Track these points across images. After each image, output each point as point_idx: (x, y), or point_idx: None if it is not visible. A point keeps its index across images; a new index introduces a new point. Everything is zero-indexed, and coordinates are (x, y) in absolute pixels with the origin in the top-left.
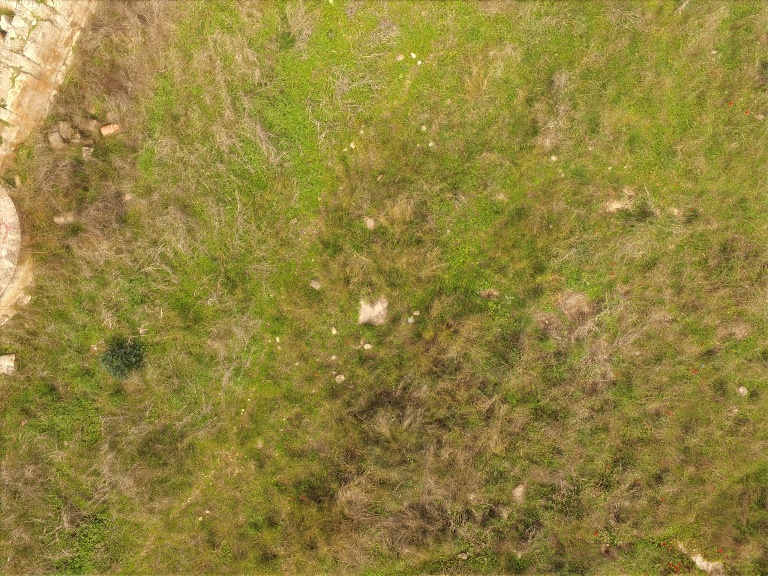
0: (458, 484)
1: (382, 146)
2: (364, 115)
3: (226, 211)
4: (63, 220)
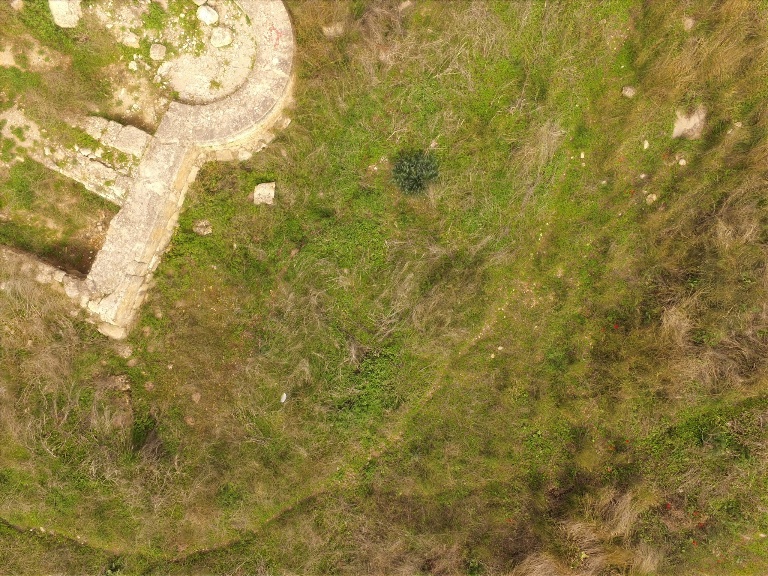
0: None
1: None
2: None
3: (531, 9)
4: (333, 30)
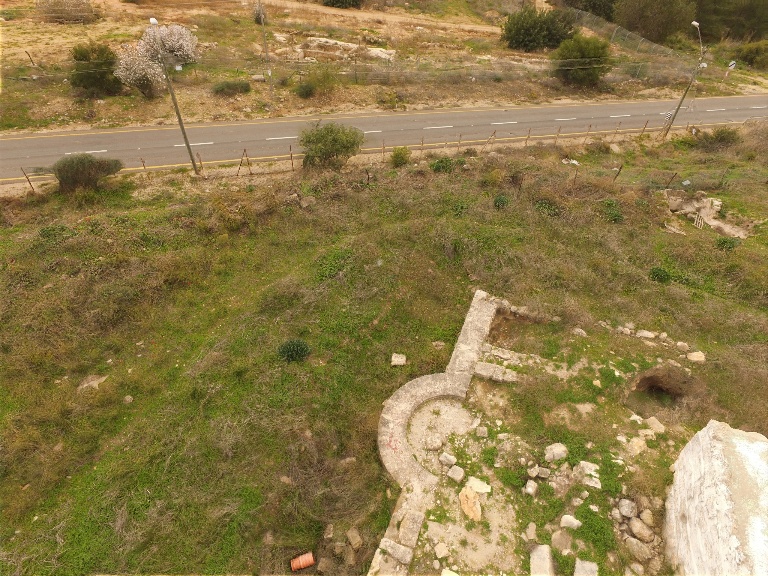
0: (81, 284)
1: (4, 516)
2: (4, 550)
3: None
4: (348, 459)
